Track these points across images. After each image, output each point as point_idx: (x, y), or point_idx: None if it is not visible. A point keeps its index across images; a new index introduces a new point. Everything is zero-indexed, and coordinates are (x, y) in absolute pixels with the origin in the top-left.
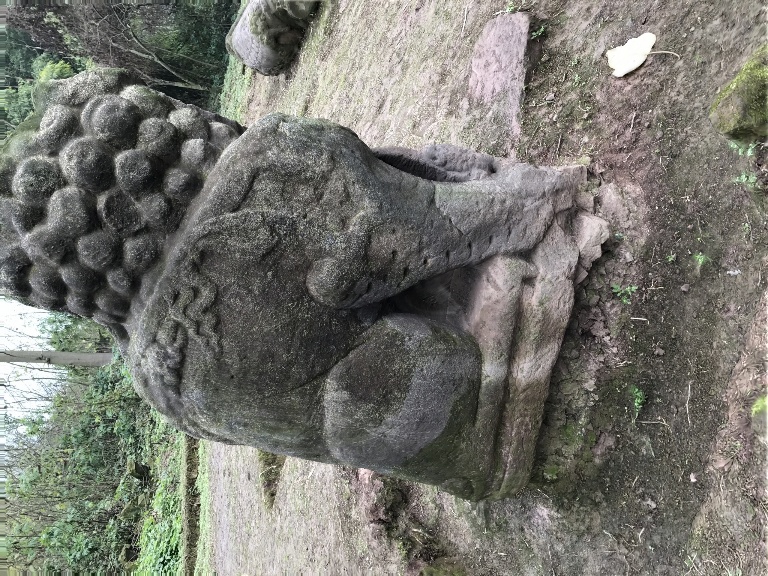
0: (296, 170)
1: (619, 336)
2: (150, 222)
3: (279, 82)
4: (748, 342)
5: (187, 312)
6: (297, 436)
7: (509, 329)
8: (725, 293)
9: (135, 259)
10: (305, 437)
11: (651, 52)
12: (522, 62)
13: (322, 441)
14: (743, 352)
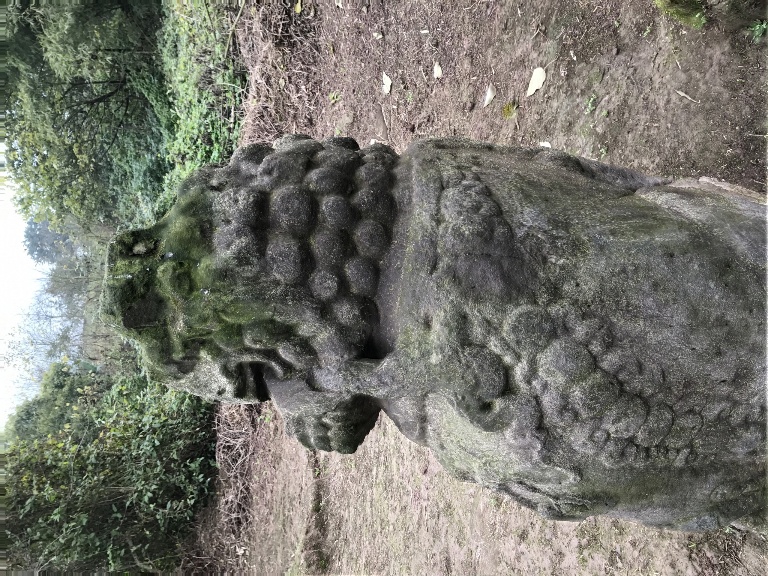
0: None
1: None
2: None
3: None
4: None
5: (458, 161)
6: (679, 231)
7: (736, 193)
8: None
9: (379, 155)
10: (688, 231)
11: None
12: None
13: (710, 237)
14: None
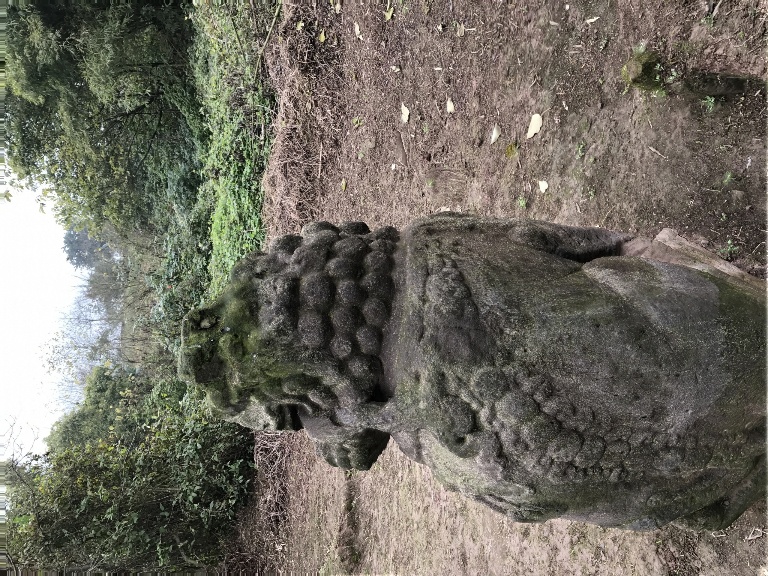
0: (455, 212)
1: (762, 263)
2: (379, 237)
3: None
4: (759, 69)
5: (442, 248)
6: (605, 306)
7: (679, 253)
8: (761, 171)
9: (382, 243)
10: (613, 305)
11: (601, 226)
12: None
13: (631, 308)
14: (766, 74)
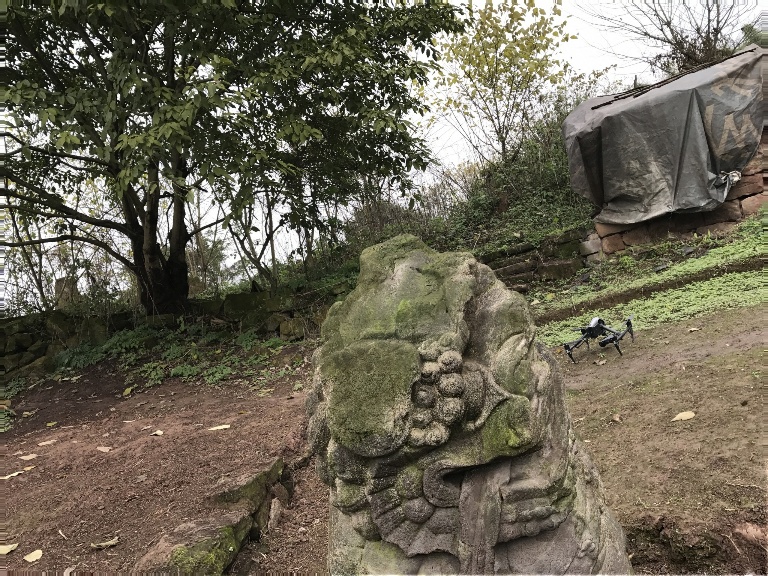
0: None
1: None
2: None
3: None
4: None
5: None
6: None
7: None
8: None
9: None
10: None
11: None
12: None
13: None
14: None
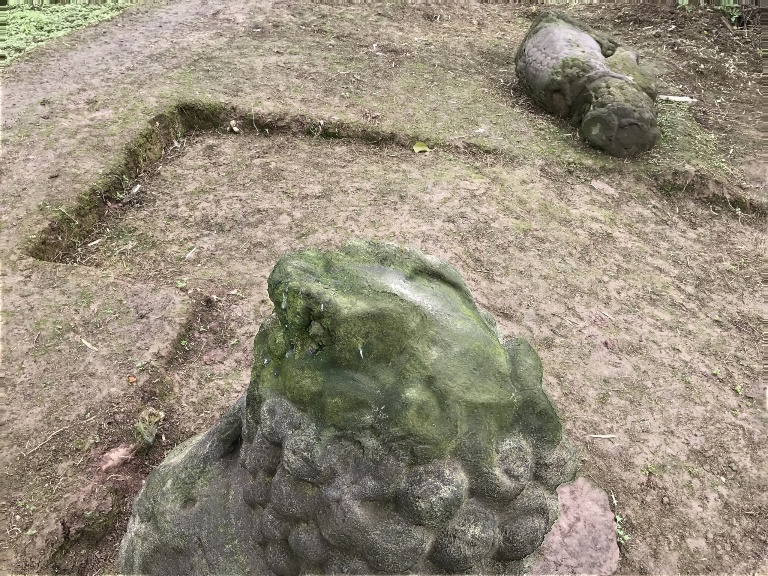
0: None
1: None
2: None
3: (508, 64)
4: None
5: None
6: None
7: None
8: None
9: None
10: None
11: None
12: (573, 574)
13: None
14: None
